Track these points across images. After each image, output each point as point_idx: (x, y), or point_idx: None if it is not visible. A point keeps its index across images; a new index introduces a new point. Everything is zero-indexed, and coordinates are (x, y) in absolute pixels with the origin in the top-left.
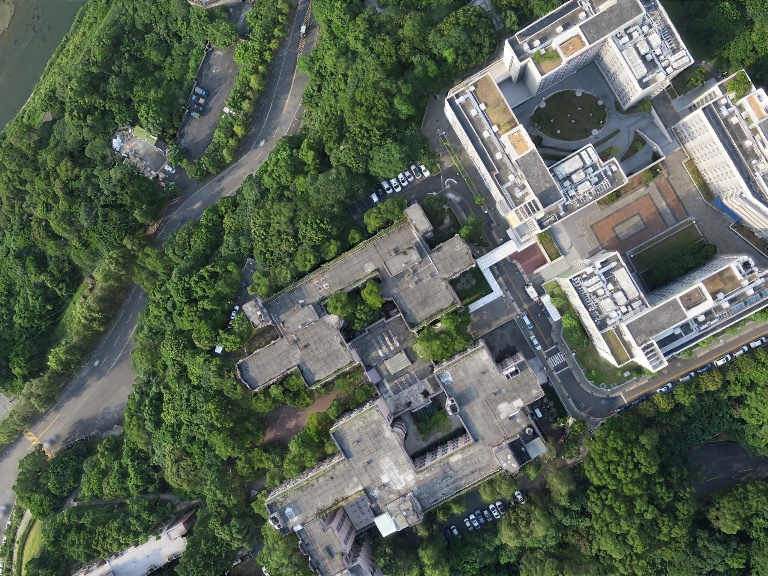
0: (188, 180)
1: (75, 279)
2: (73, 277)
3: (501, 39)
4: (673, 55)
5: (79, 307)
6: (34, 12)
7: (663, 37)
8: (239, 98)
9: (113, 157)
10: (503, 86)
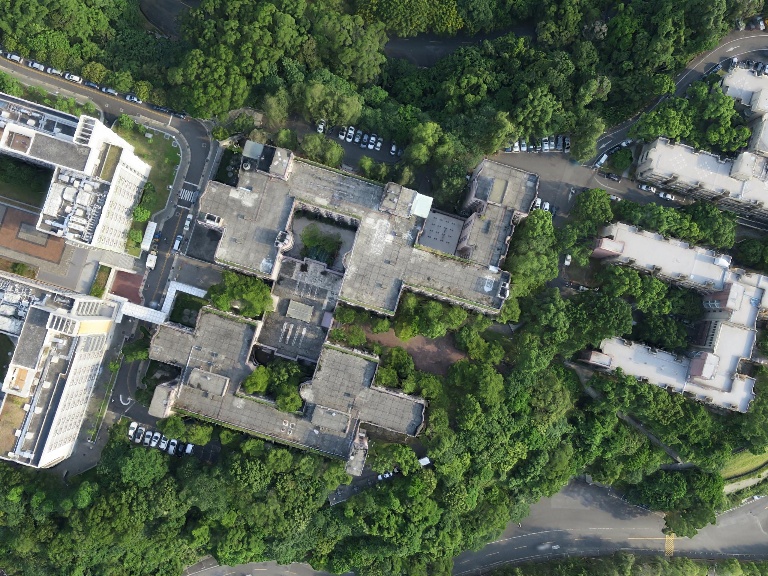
0: None
1: None
2: None
3: None
4: None
5: None
6: None
7: None
8: None
9: None
10: None
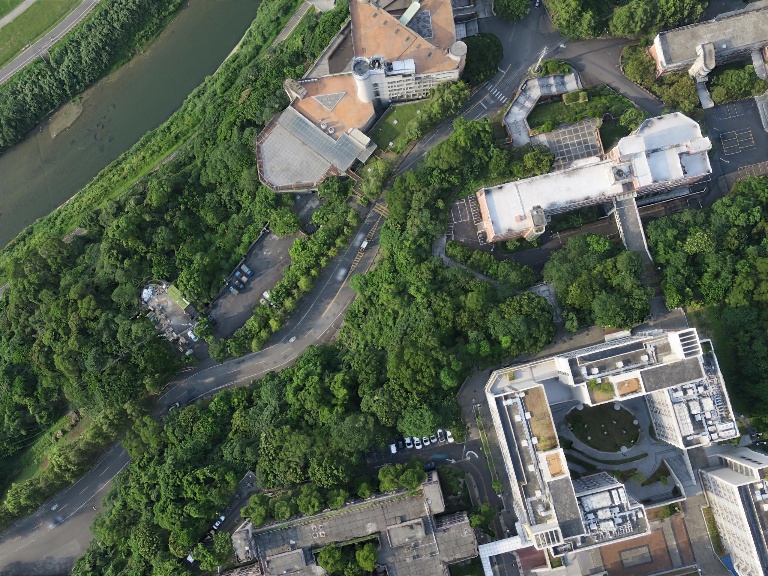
0: (207, 353)
1: (59, 409)
2: (58, 406)
3: (556, 332)
4: (721, 423)
5: (57, 454)
6: (100, 120)
7: (715, 402)
8: (283, 293)
9: (139, 307)
10: (548, 381)
